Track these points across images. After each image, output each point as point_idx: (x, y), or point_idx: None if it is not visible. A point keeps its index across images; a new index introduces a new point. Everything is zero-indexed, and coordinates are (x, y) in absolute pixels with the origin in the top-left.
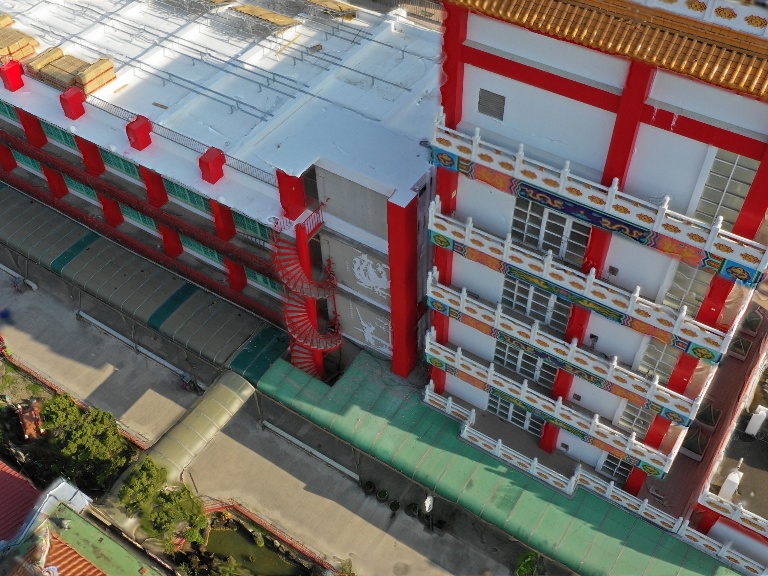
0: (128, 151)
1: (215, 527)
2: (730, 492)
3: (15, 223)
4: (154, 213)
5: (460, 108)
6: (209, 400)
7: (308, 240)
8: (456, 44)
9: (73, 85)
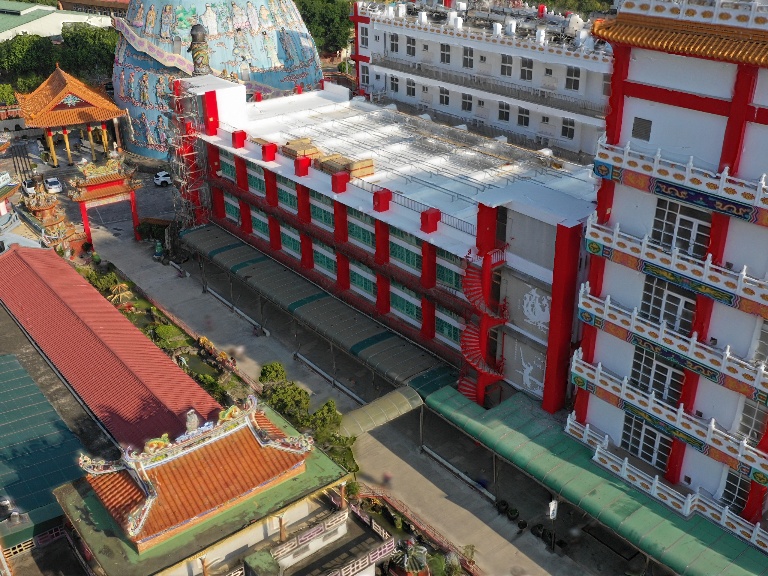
0: (371, 211)
1: (364, 508)
2: None
3: (270, 279)
4: (377, 267)
5: (619, 134)
6: (385, 399)
7: (491, 269)
8: (619, 81)
9: (343, 170)
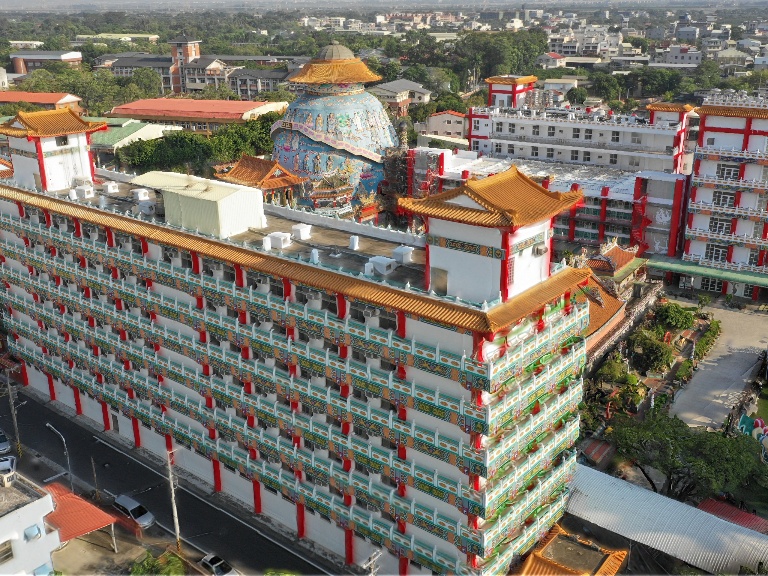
0: None
1: None
2: None
3: None
4: None
5: (702, 144)
6: None
7: None
8: (703, 127)
9: (545, 179)
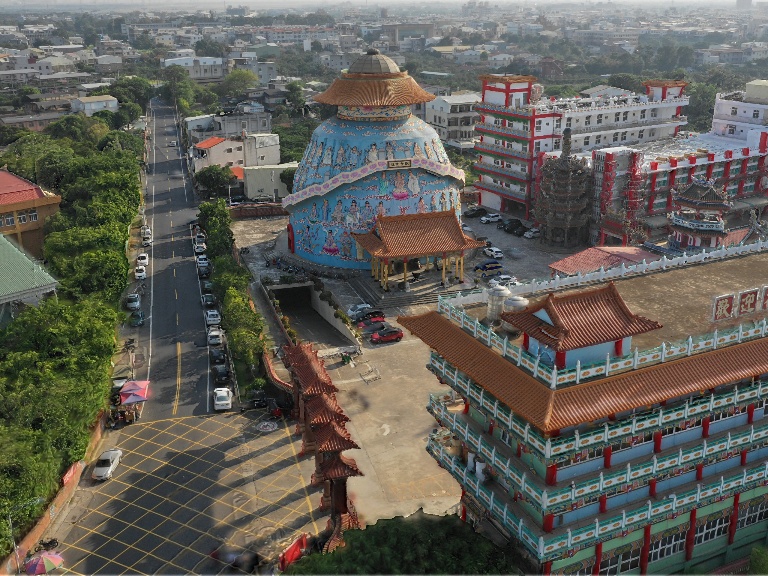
0: None
1: None
2: None
3: None
4: None
5: None
6: None
7: None
8: None
9: (708, 153)
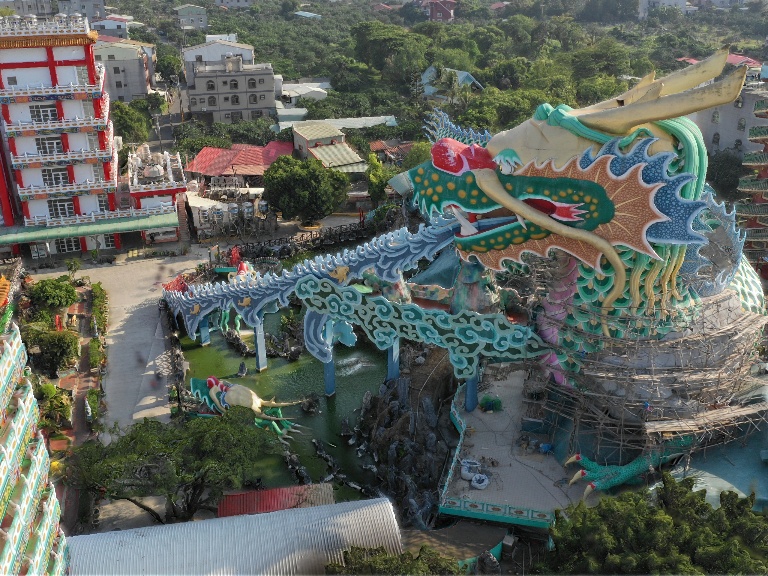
0: None
1: None
2: (136, 184)
3: None
4: None
5: (3, 85)
6: None
7: None
8: None
9: None
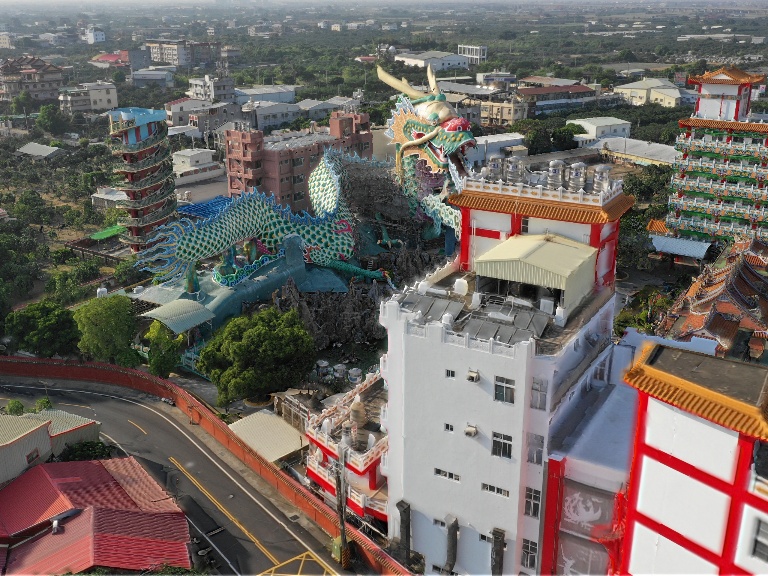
0: None
1: None
2: None
3: None
4: None
5: None
6: None
7: None
8: None
9: None
